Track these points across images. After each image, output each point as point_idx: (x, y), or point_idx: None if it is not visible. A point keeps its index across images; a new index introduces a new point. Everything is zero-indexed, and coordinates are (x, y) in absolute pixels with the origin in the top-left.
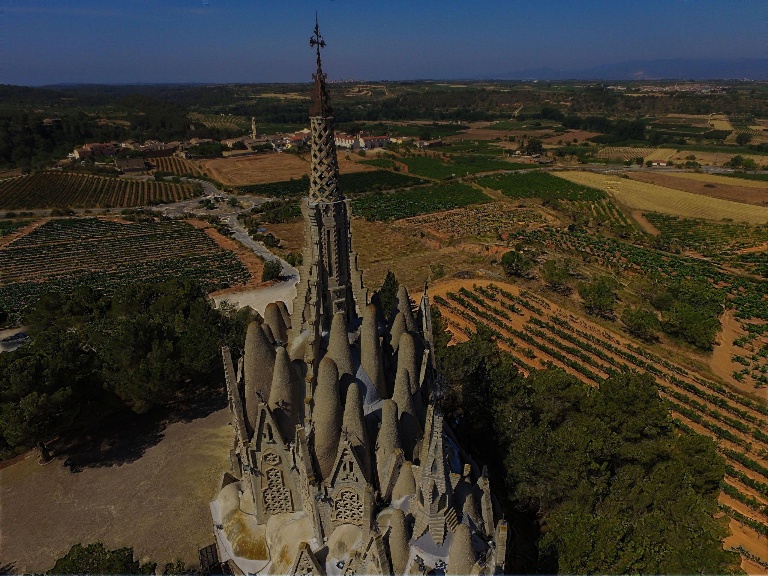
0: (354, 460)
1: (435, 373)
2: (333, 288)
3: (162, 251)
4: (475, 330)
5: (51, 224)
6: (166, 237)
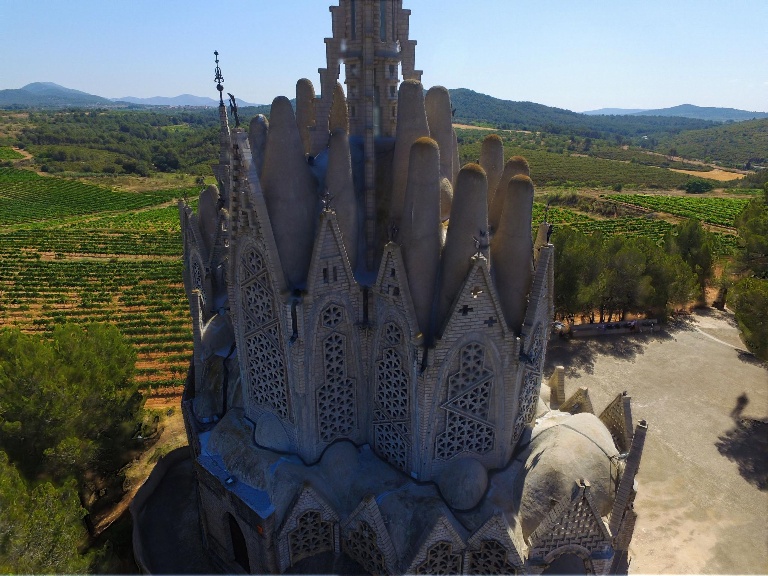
0: None
1: None
2: None
3: None
4: None
5: None
6: None
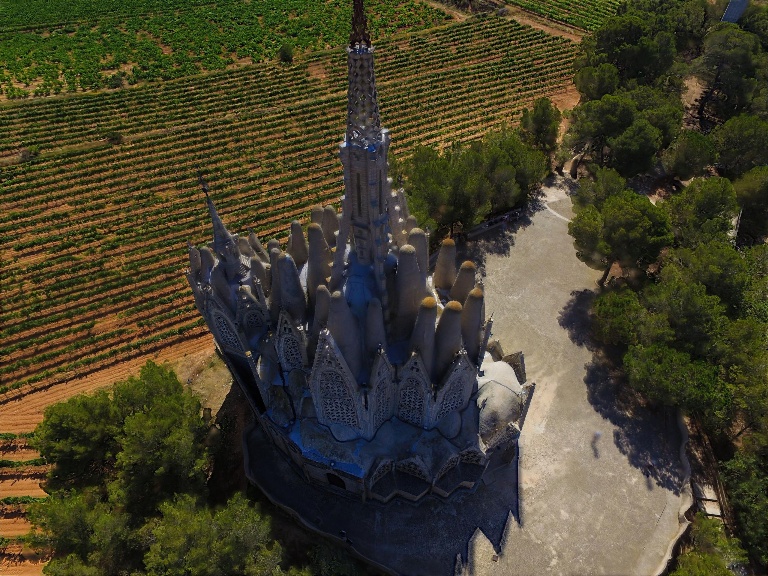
0: None
1: None
2: None
3: None
4: None
5: None
6: None
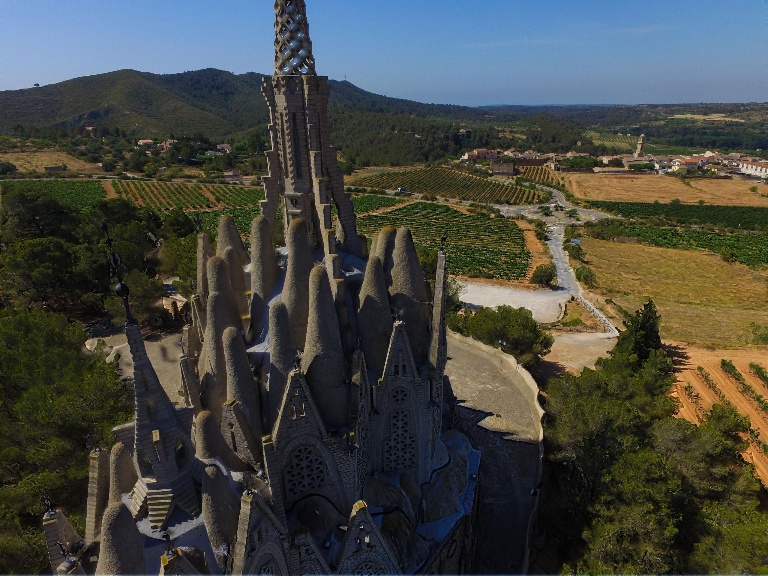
0: (186, 382)
1: (432, 371)
2: (287, 192)
3: (475, 240)
4: (766, 431)
5: (416, 204)
6: (487, 230)
